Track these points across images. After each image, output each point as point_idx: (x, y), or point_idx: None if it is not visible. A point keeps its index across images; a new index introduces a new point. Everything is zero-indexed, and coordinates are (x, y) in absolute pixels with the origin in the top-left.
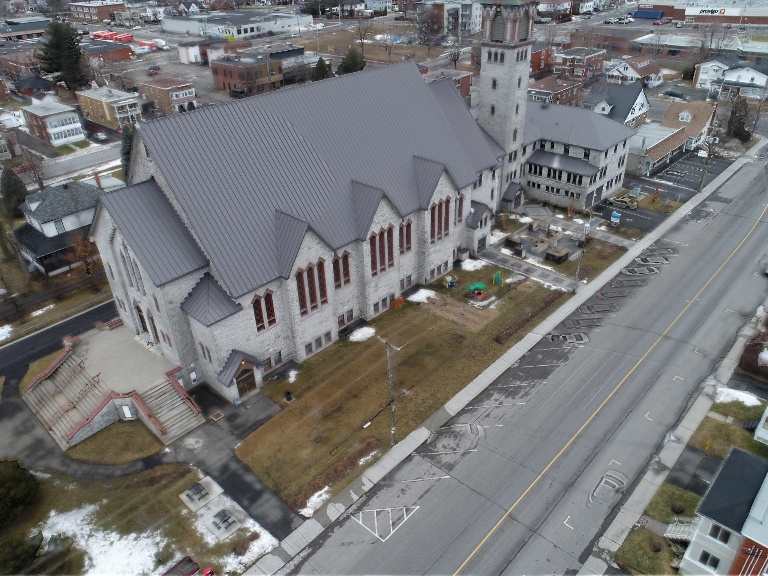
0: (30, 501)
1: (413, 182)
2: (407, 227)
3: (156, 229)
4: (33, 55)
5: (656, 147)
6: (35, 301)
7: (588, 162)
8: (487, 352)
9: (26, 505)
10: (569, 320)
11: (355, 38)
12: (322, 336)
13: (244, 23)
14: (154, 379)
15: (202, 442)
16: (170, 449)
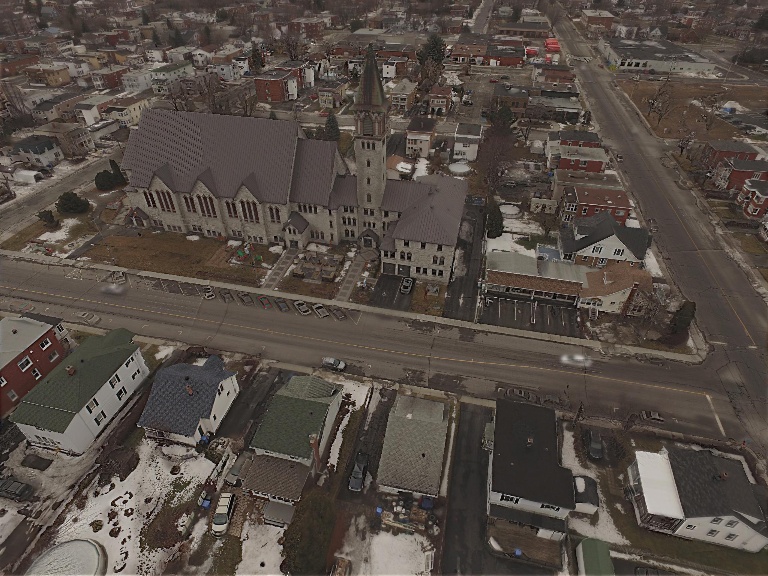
0: (81, 213)
1: None
2: (234, 205)
3: None
4: (416, 52)
5: (508, 275)
6: None
7: None
8: (187, 272)
9: (77, 212)
10: (228, 290)
11: None
12: (176, 226)
13: None
14: None
15: None
16: None
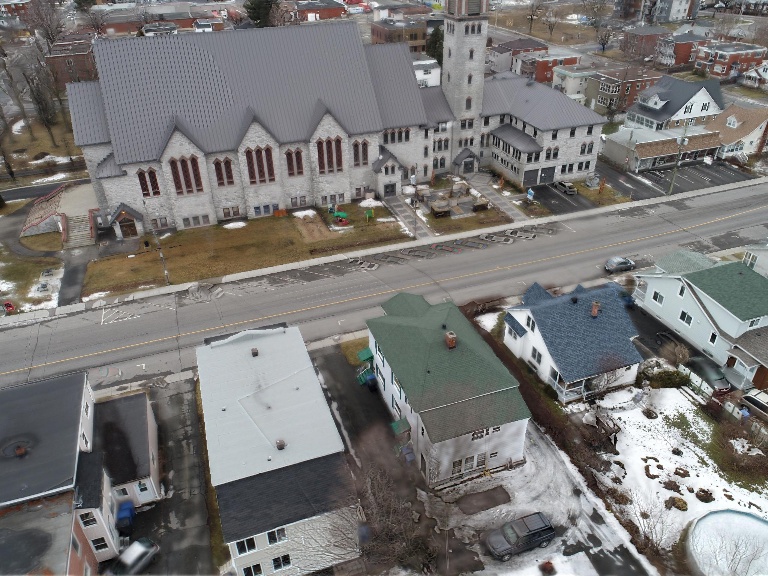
0: None
1: (308, 119)
2: (298, 154)
3: (92, 111)
4: (243, 5)
5: (655, 144)
6: None
7: (535, 140)
8: (295, 256)
9: None
10: (383, 254)
11: (527, 14)
12: (200, 216)
13: None
14: (83, 212)
15: (81, 253)
16: (64, 251)
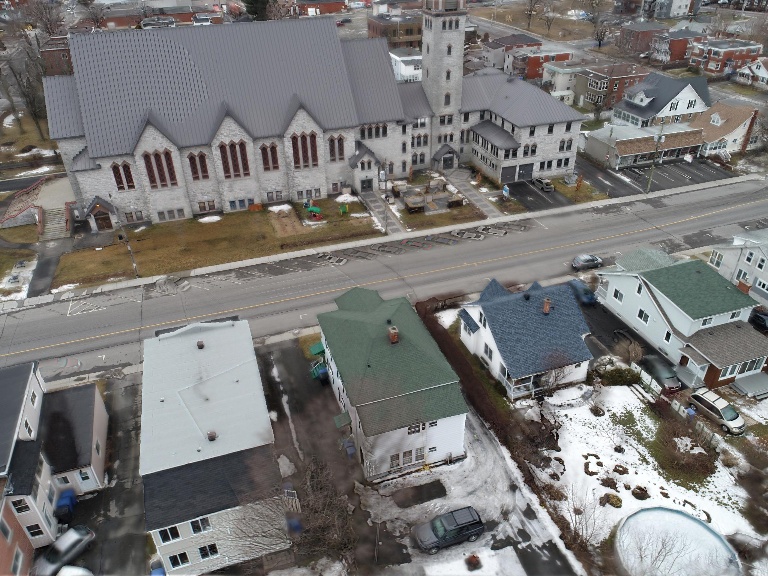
0: None
1: (283, 114)
2: (273, 149)
3: (68, 105)
4: None
5: (636, 142)
6: None
7: (513, 137)
8: (265, 250)
9: None
10: (353, 249)
11: None
12: (175, 210)
13: None
14: (60, 205)
15: (55, 245)
16: (39, 244)
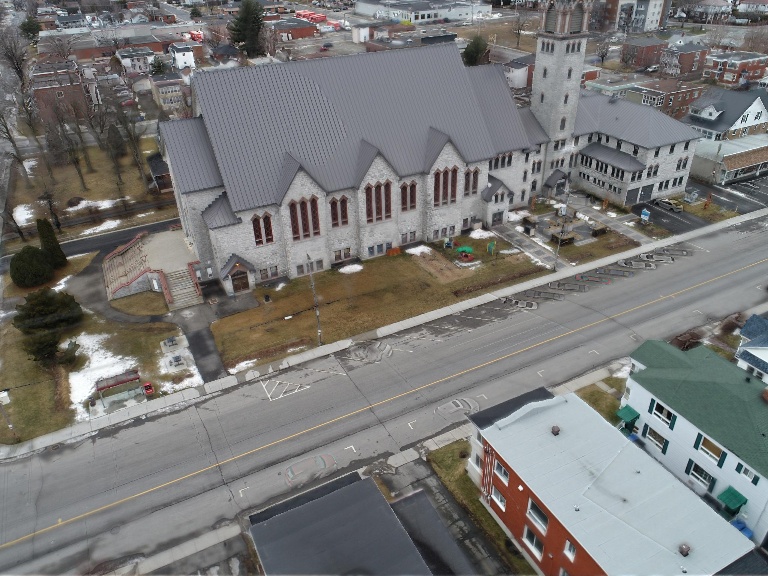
0: (74, 323)
1: (423, 149)
2: (412, 187)
3: (193, 153)
4: (226, 27)
5: (739, 156)
6: (144, 208)
7: (636, 159)
8: (440, 300)
9: (70, 324)
10: (532, 291)
11: (513, 28)
12: (314, 262)
13: (423, 9)
14: (180, 266)
15: (194, 314)
16: (171, 314)
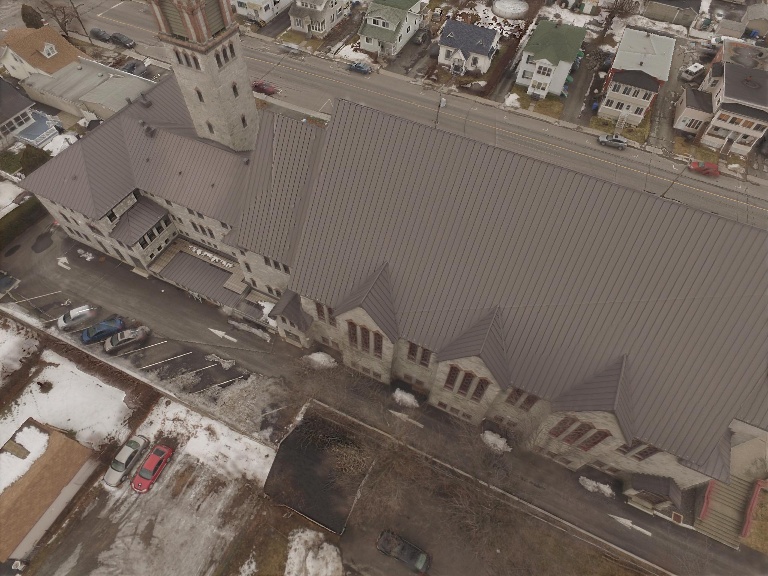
0: None
1: None
2: None
3: None
4: None
5: None
6: None
7: None
8: None
9: None
10: None
11: None
12: None
13: None
14: None
15: None
16: None
